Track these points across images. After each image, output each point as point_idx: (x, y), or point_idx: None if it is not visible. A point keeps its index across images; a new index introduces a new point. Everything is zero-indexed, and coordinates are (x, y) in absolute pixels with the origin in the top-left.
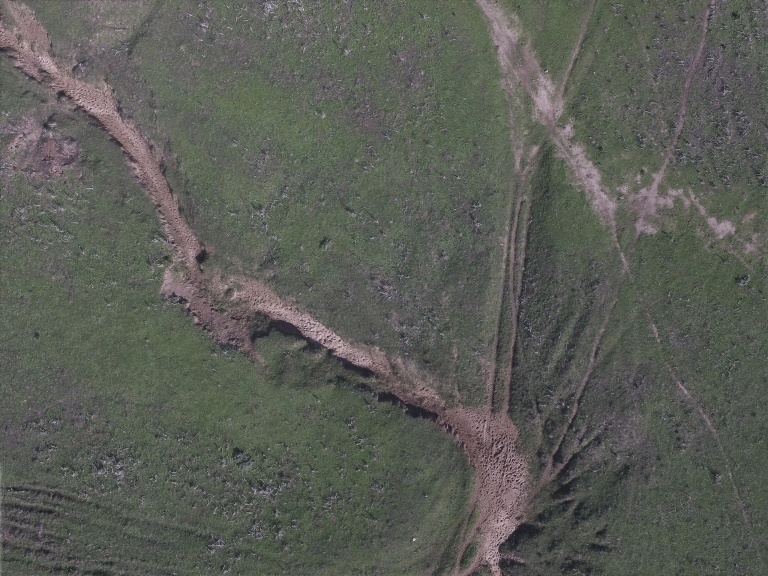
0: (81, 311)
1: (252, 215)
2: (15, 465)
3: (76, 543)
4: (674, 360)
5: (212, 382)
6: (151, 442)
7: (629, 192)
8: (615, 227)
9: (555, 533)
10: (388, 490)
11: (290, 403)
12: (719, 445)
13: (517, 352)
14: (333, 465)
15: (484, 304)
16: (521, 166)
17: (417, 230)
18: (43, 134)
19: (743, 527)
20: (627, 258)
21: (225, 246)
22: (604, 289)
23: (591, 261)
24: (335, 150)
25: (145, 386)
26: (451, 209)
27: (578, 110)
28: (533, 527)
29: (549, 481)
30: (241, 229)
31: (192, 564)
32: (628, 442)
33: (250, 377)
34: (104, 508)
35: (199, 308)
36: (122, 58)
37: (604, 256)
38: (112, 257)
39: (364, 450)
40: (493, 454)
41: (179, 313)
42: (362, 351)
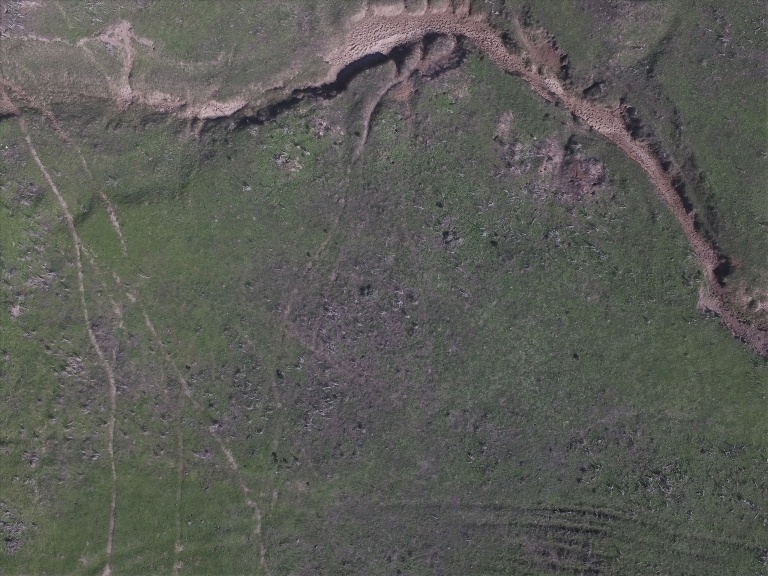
0: (620, 330)
1: None
2: (560, 486)
3: (625, 561)
4: None
5: (757, 394)
6: (697, 457)
7: None
8: None
9: None
10: None
11: None
12: None
13: None
14: None
15: None
16: None
17: None
18: (567, 156)
19: None
20: None
21: (753, 258)
22: None
23: None
24: None
25: (688, 401)
26: None
27: None
28: None
29: None
30: None
31: None
32: None
33: None
34: (650, 525)
35: (730, 321)
36: (640, 76)
37: None
38: (646, 274)
39: None
40: None
41: (718, 327)
42: None
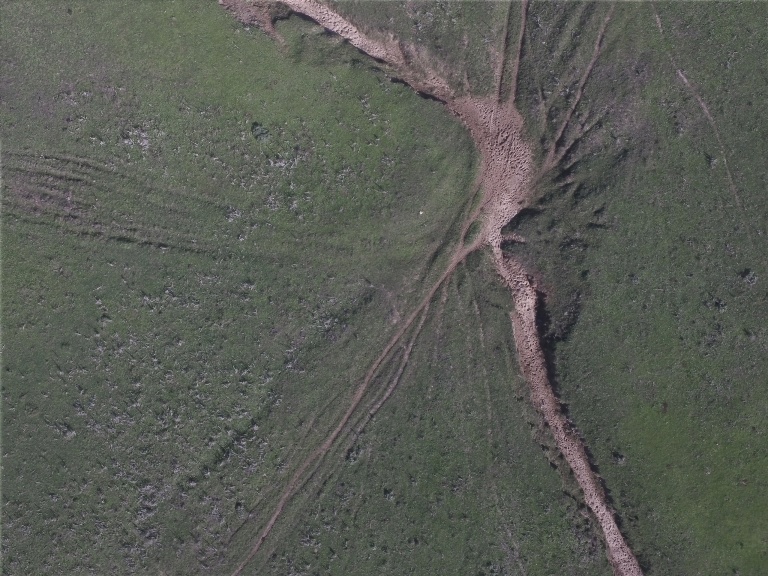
0: None
1: None
2: (47, 134)
3: (102, 210)
4: (675, 50)
5: (234, 58)
6: (175, 115)
7: None
8: None
9: (555, 214)
10: (398, 164)
11: (307, 80)
12: (715, 132)
13: (525, 43)
14: (346, 140)
15: None
16: None
17: None
18: None
19: (735, 210)
20: None
21: None
22: None
23: None
24: None
25: (171, 62)
26: None
27: None
28: (534, 210)
29: (551, 168)
30: None
31: (211, 232)
32: (628, 127)
33: (270, 54)
34: (129, 178)
35: None
36: None
37: None
38: None
39: (376, 125)
40: (498, 143)
41: None
42: (377, 42)
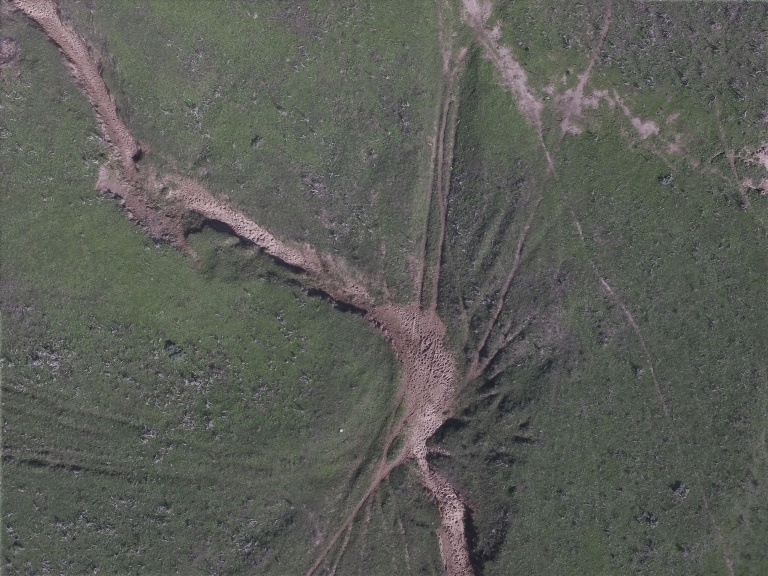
0: (18, 206)
1: (186, 113)
2: None
3: (12, 433)
4: (597, 257)
5: (145, 276)
6: (86, 334)
7: (555, 93)
8: (541, 127)
9: (480, 426)
10: (316, 382)
11: (221, 296)
12: (641, 340)
13: (445, 250)
14: (263, 357)
15: (412, 201)
16: (449, 67)
17: (347, 129)
18: None
19: (664, 421)
20: (552, 157)
21: (160, 145)
22: (529, 187)
23: (517, 159)
24: (267, 50)
25: (80, 280)
26: (380, 108)
27: (505, 12)
28: (459, 421)
29: (475, 376)
30: (175, 128)
31: (125, 454)
32: (552, 337)
33: (182, 271)
34: (40, 399)
35: (134, 205)
36: None
37: (530, 155)
38: (49, 154)
39: (293, 342)
40: (421, 351)
41: (114, 208)
42: (294, 250)
